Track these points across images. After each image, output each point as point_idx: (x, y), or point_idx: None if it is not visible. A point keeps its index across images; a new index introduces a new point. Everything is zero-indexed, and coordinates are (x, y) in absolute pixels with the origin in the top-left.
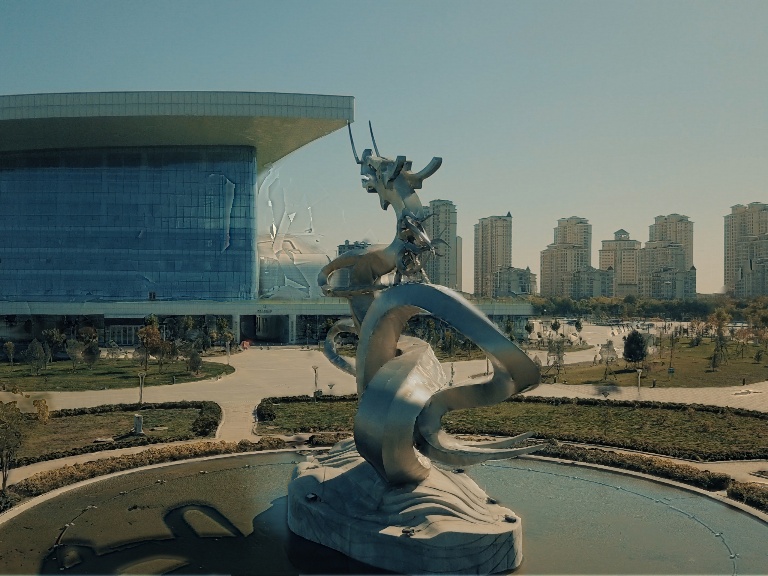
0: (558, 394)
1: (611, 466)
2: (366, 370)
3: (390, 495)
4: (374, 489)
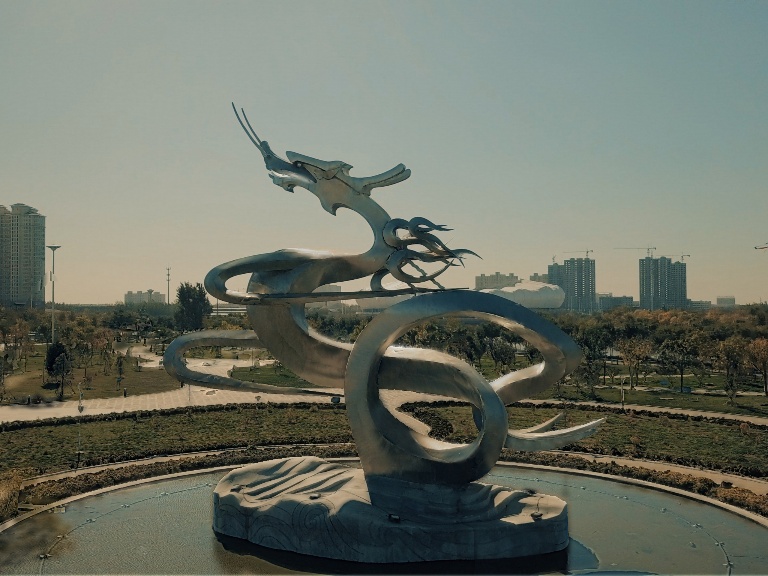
0: (78, 412)
1: (341, 457)
2: (369, 380)
3: (471, 494)
4: (438, 494)
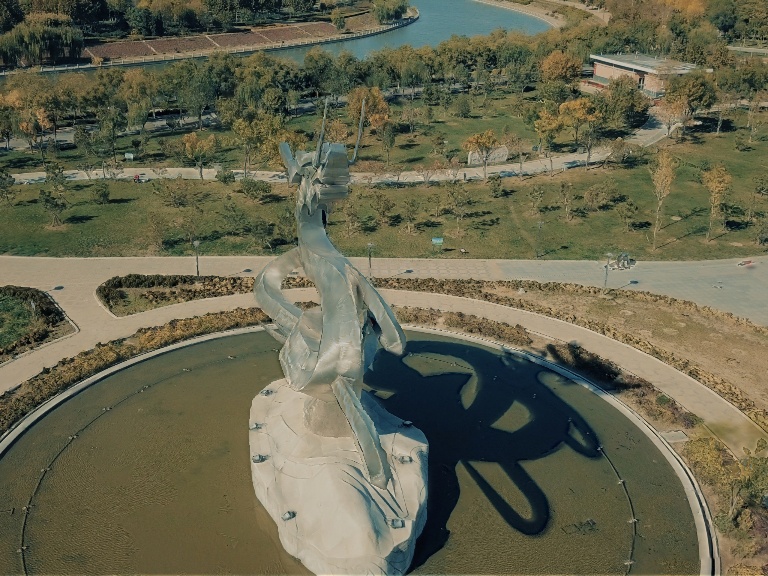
0: None
1: None
2: None
3: None
4: None
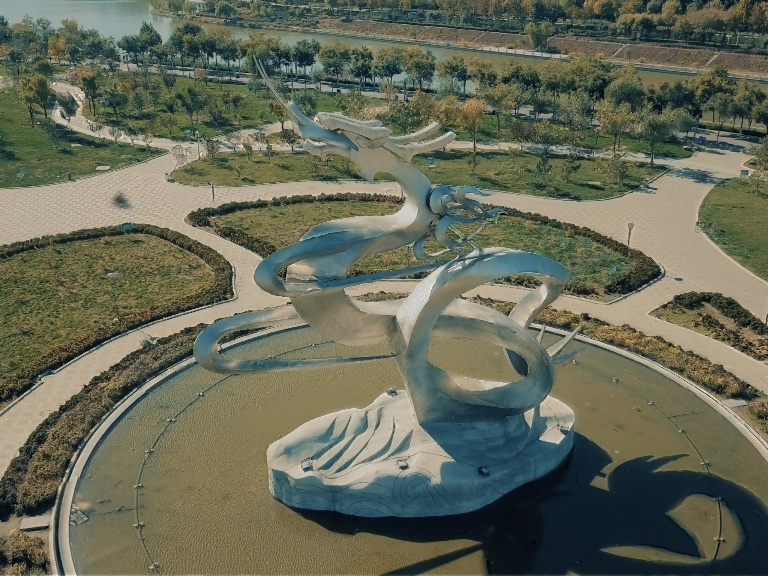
0: None
1: (242, 335)
2: None
3: (514, 423)
4: (490, 431)
